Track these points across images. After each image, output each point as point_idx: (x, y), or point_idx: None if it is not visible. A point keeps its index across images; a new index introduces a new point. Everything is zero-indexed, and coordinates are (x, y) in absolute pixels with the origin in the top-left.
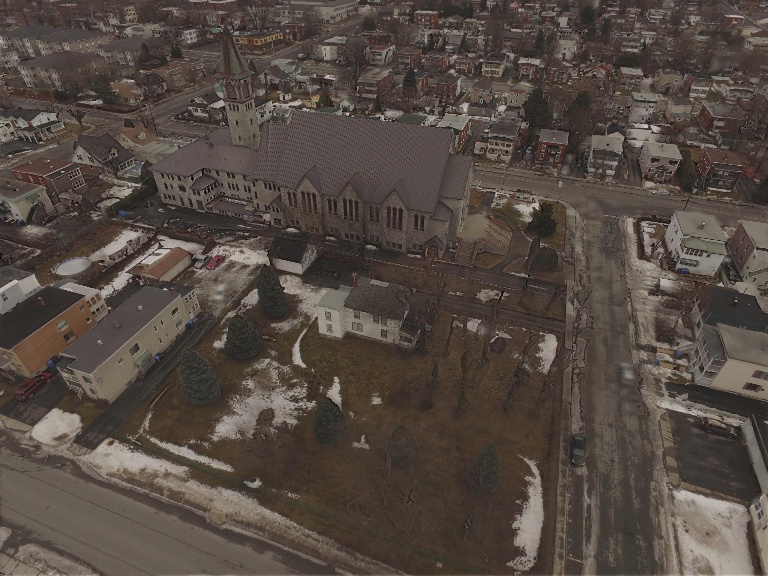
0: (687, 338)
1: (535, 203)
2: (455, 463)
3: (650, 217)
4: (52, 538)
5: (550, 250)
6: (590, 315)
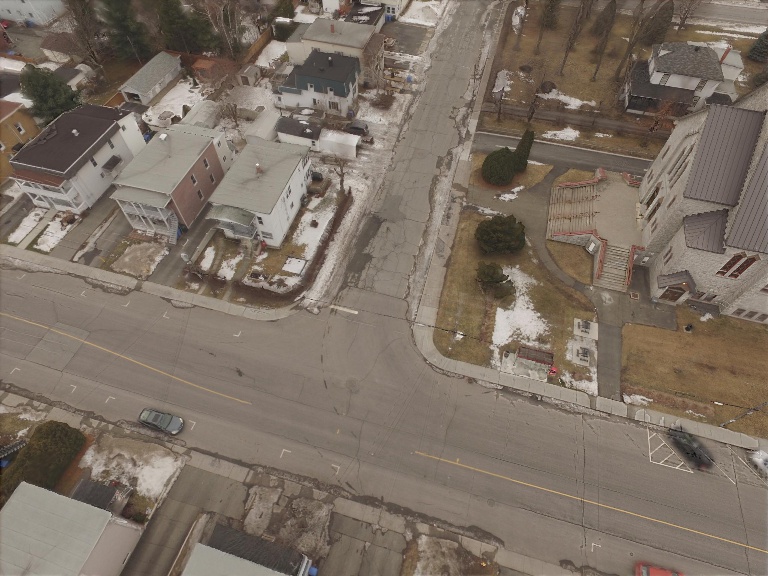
0: (364, 99)
1: (502, 344)
2: (566, 31)
3: (265, 308)
4: (757, 10)
5: (501, 153)
6: (452, 119)
